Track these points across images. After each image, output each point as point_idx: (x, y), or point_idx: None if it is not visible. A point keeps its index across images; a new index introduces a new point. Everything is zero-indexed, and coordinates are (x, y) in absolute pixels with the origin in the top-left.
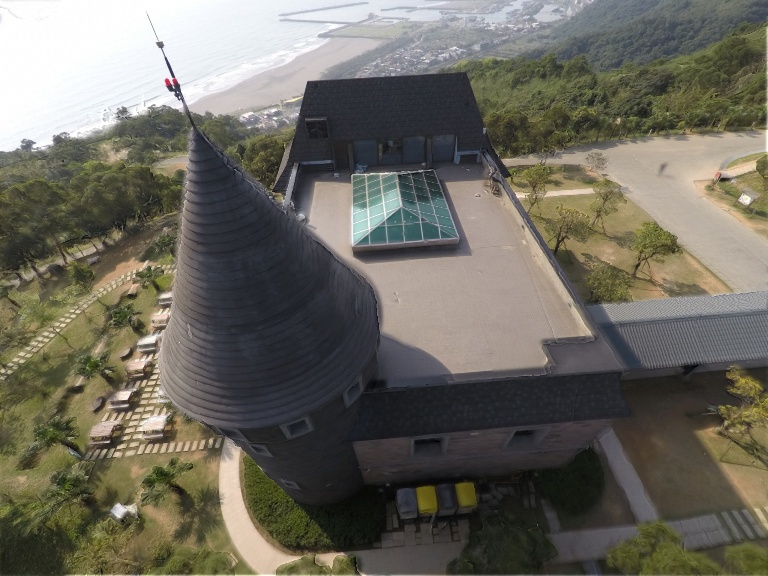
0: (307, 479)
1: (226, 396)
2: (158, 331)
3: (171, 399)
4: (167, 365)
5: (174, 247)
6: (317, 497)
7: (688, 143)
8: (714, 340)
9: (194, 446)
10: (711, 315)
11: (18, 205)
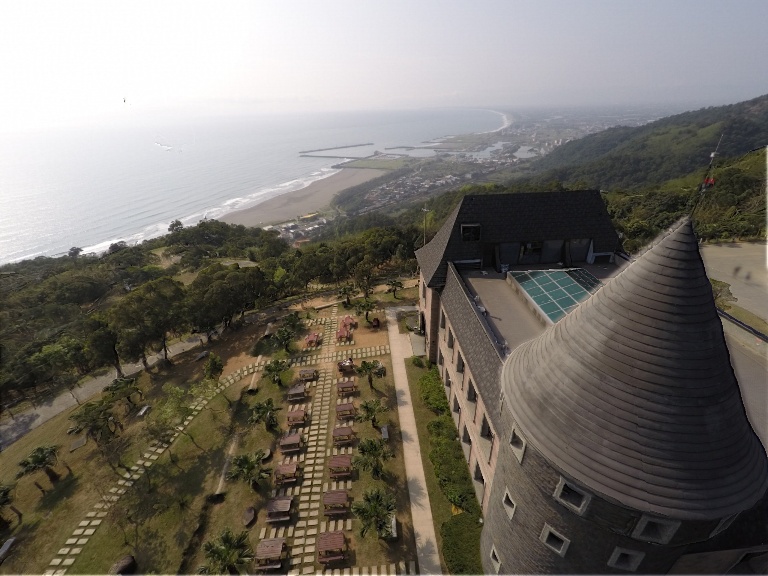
0: None
1: (680, 479)
2: (295, 429)
3: (600, 485)
4: (579, 445)
5: None
6: None
7: (743, 250)
8: None
9: (384, 572)
10: None
11: (148, 300)
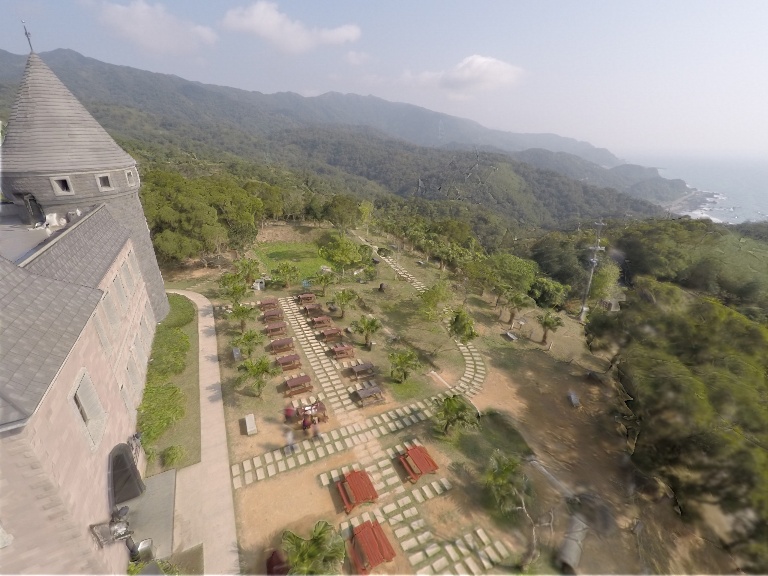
0: None
1: None
2: None
3: None
4: None
5: (482, 460)
6: None
7: None
8: None
9: None
10: None
11: (686, 320)
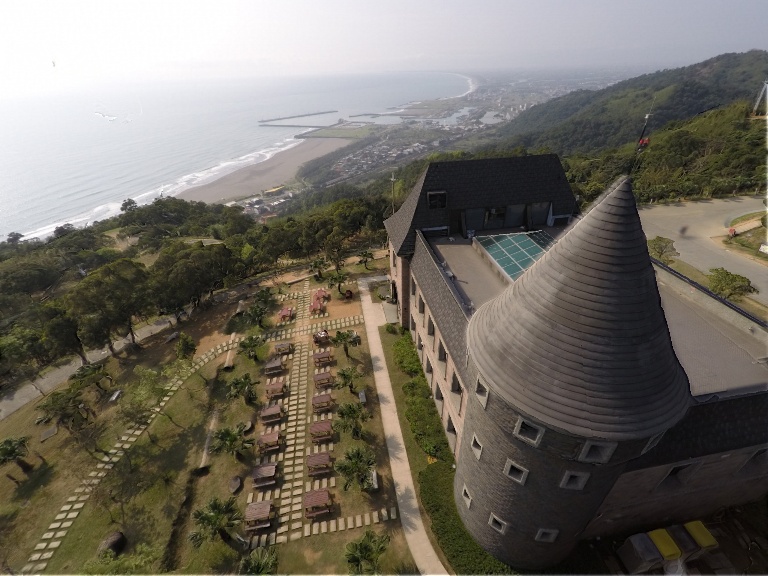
0: (572, 524)
1: (617, 407)
2: (274, 401)
3: (551, 418)
4: (534, 387)
5: None
6: (552, 554)
7: (687, 208)
8: None
9: (367, 520)
10: None
11: (108, 284)
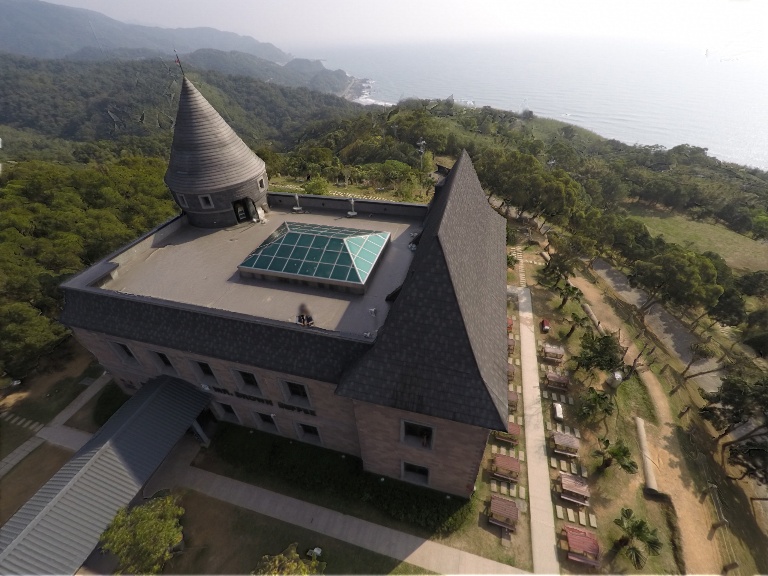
0: None
1: None
2: None
3: None
4: None
5: None
6: None
7: None
8: None
9: None
10: None
11: (507, 161)
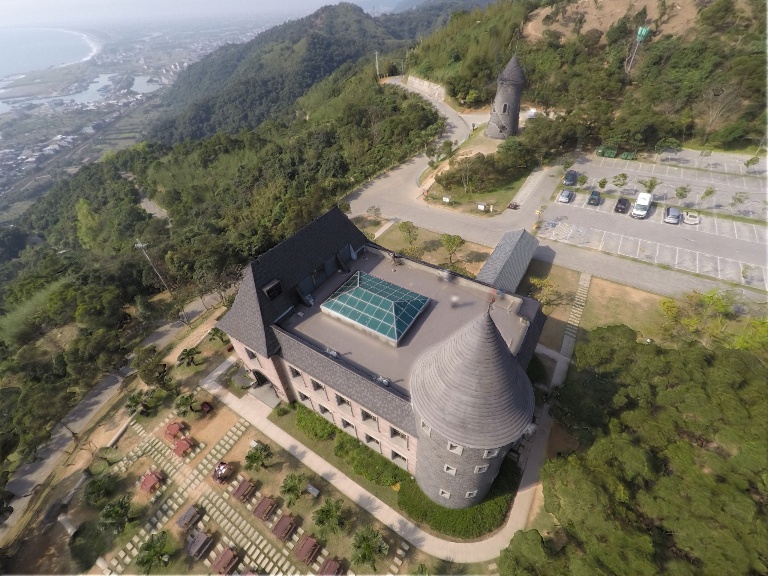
0: None
1: (522, 415)
2: (235, 572)
3: (505, 443)
4: (490, 434)
5: None
6: None
7: (392, 178)
8: (513, 272)
9: (395, 569)
10: (505, 263)
11: None
